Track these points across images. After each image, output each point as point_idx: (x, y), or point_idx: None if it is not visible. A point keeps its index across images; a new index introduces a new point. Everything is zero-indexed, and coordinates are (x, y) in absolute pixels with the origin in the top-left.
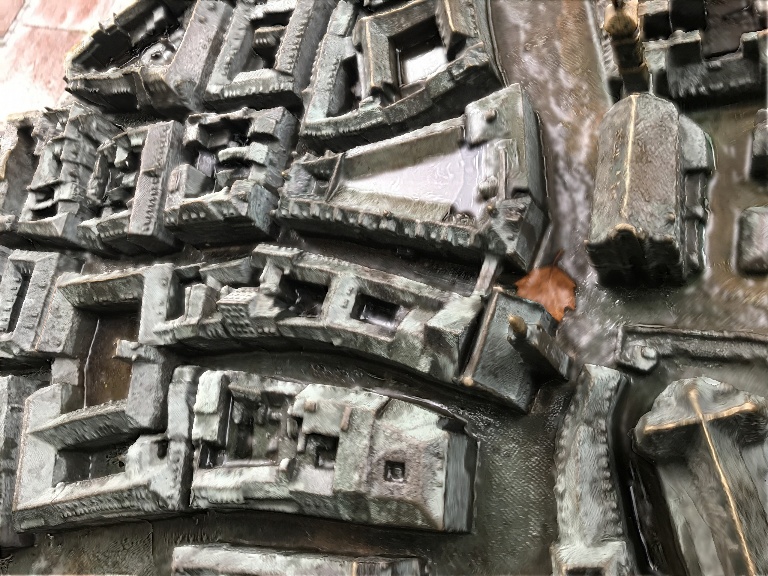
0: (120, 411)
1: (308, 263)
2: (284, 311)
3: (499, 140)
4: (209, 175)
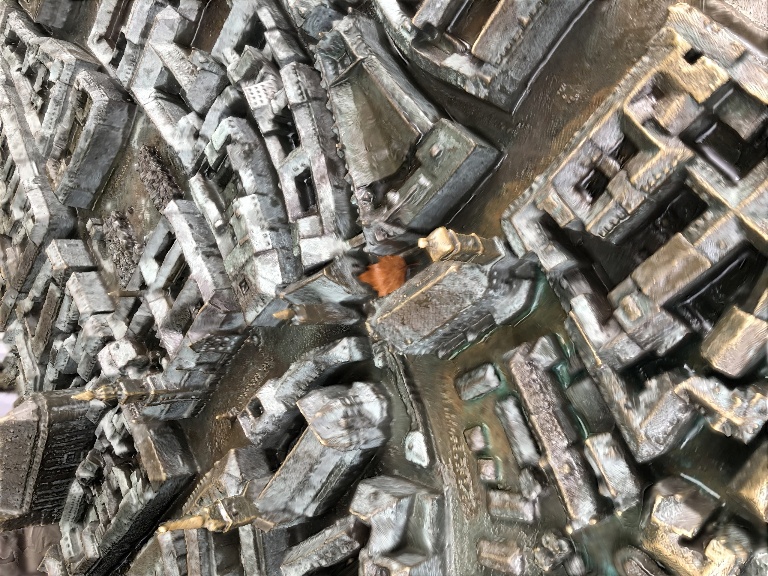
0: (185, 91)
1: (298, 118)
2: (275, 130)
3: (424, 175)
4: None
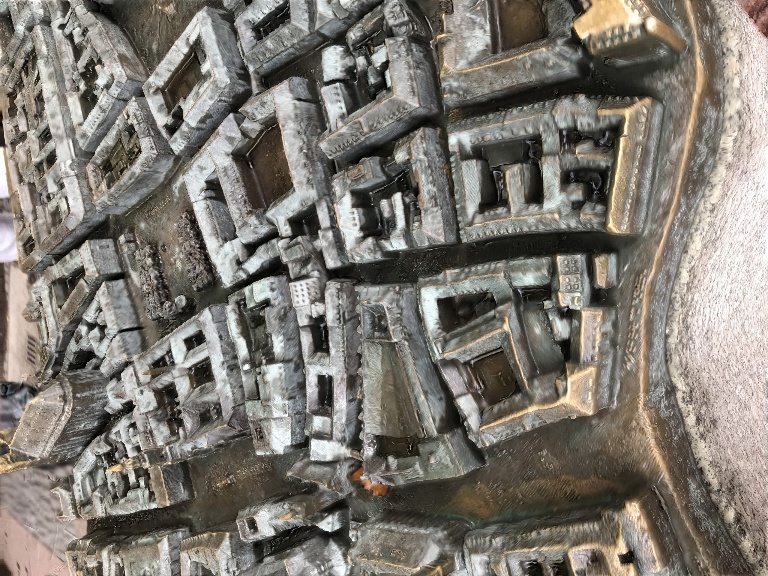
0: None
1: (331, 337)
2: None
3: (420, 465)
4: (394, 174)
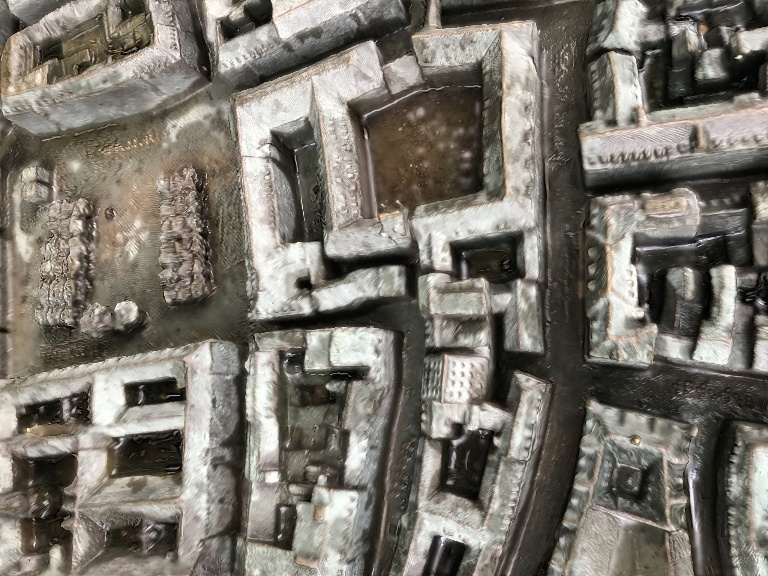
0: (332, 222)
1: (503, 478)
2: None
3: None
4: (702, 232)
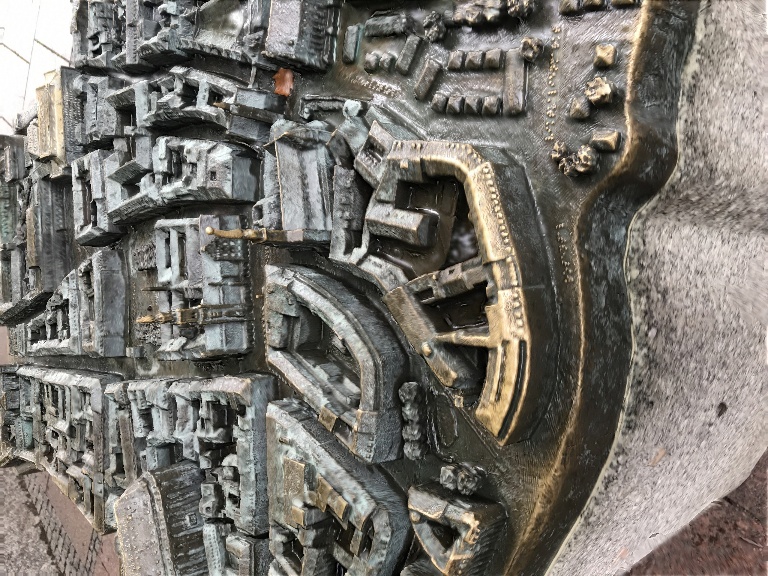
0: (134, 162)
1: (190, 76)
2: (185, 103)
3: None
4: None
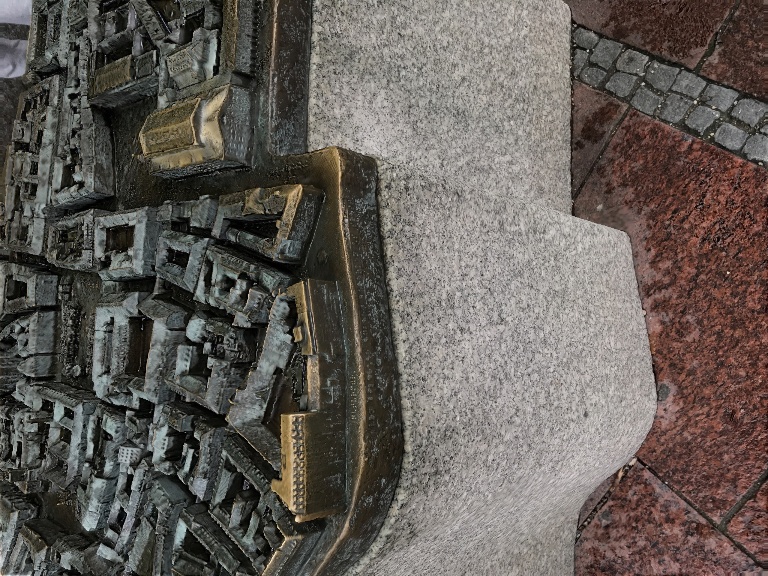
0: None
1: (132, 495)
2: None
3: None
4: None
